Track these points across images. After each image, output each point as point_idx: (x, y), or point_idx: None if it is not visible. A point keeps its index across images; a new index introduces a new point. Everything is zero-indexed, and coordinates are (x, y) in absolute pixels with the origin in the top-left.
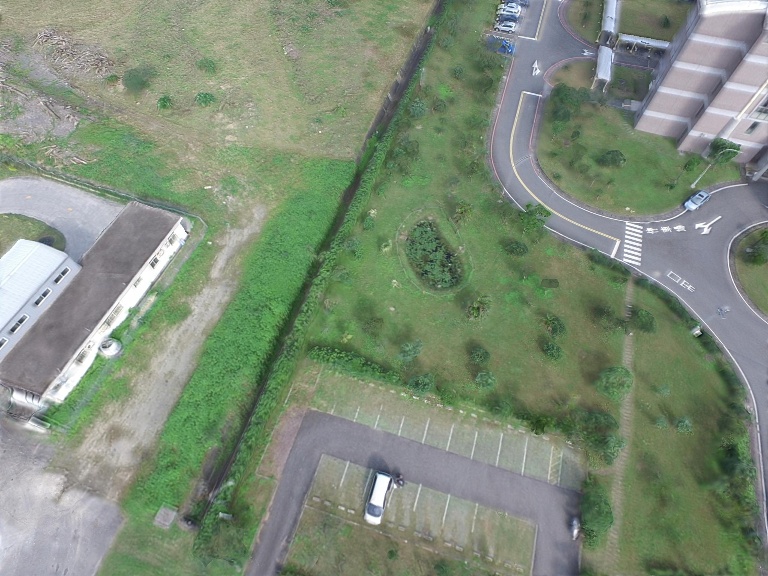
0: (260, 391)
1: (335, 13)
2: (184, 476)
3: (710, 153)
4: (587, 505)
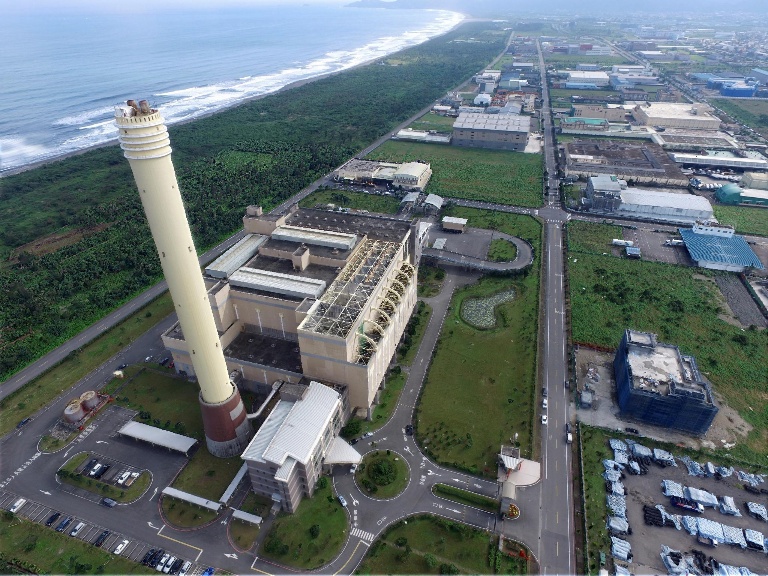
0: None
1: None
2: None
3: (321, 488)
4: None
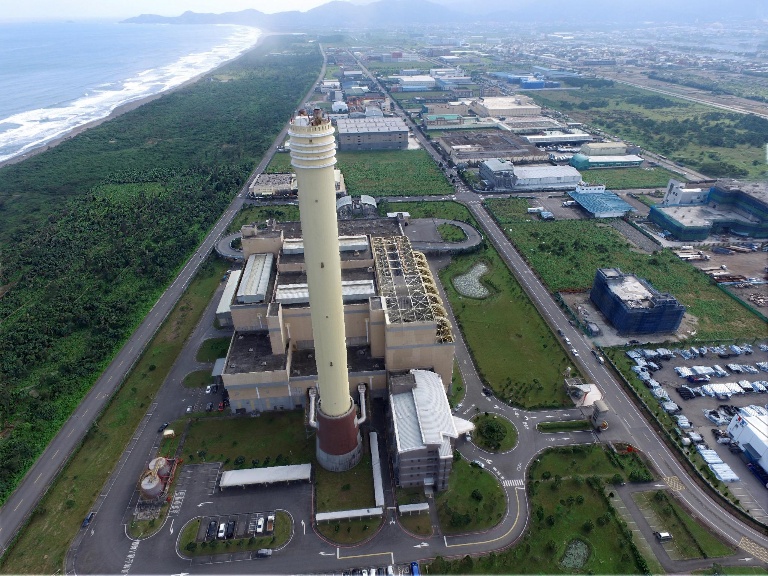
0: None
1: None
2: None
3: None
4: (619, 480)
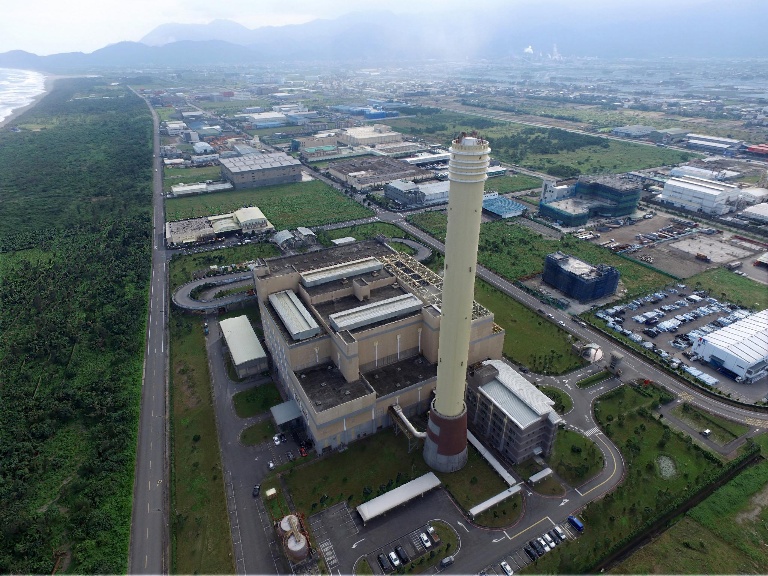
0: (740, 469)
1: None
2: (765, 463)
3: None
4: None
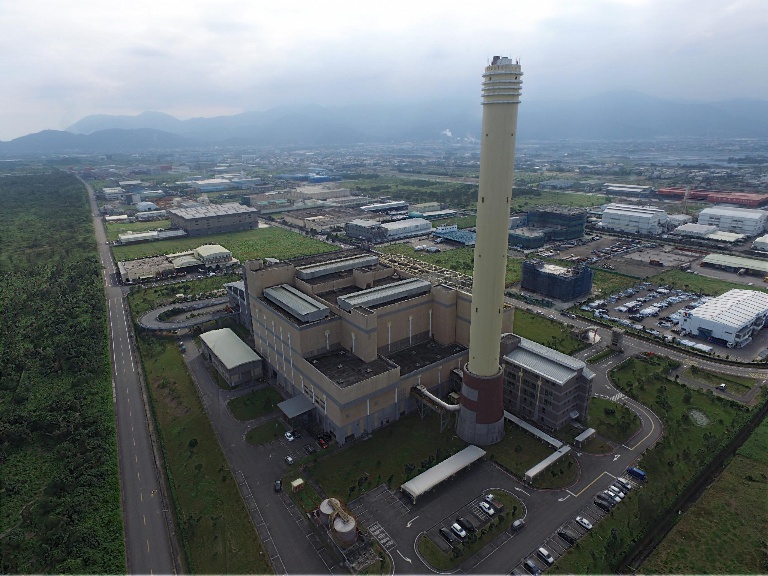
0: (765, 412)
1: (766, 544)
2: None
3: None
4: None
